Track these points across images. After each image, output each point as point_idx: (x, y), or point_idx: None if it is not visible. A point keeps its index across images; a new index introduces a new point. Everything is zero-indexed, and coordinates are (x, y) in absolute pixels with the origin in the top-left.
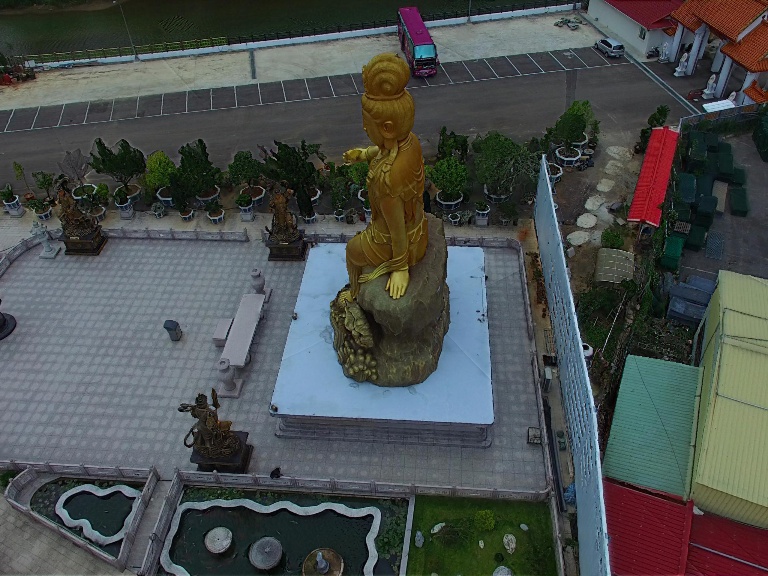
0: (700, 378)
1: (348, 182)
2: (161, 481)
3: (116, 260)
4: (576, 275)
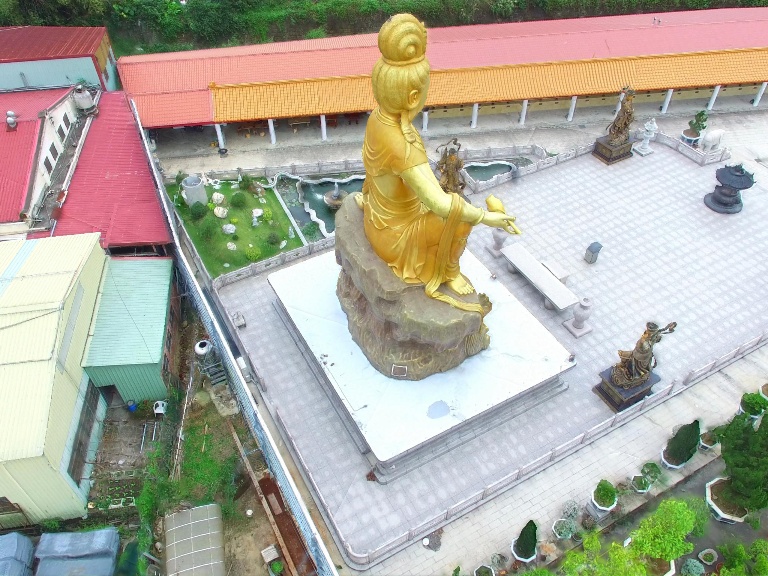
0: (87, 353)
1: (719, 574)
2: (473, 193)
3: (760, 292)
4: (257, 571)
